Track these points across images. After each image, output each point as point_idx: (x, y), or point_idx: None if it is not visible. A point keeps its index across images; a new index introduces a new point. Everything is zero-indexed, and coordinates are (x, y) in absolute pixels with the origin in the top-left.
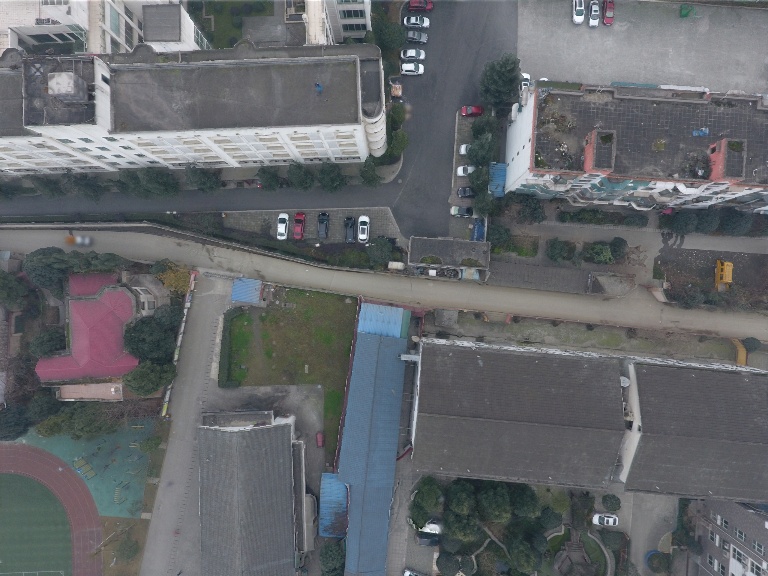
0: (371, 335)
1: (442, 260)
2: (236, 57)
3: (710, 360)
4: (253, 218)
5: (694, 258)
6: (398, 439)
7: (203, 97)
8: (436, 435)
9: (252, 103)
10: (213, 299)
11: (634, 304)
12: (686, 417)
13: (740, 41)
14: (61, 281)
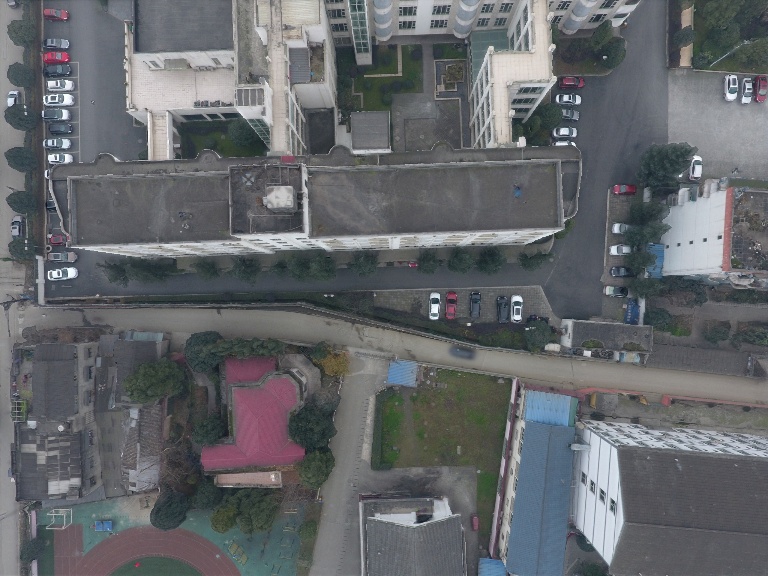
0: (541, 424)
1: (604, 344)
2: (434, 159)
3: None
4: (403, 297)
5: None
6: (567, 529)
7: (400, 199)
8: (640, 543)
9: (450, 205)
10: (363, 379)
11: None
12: None
13: None
14: (218, 365)
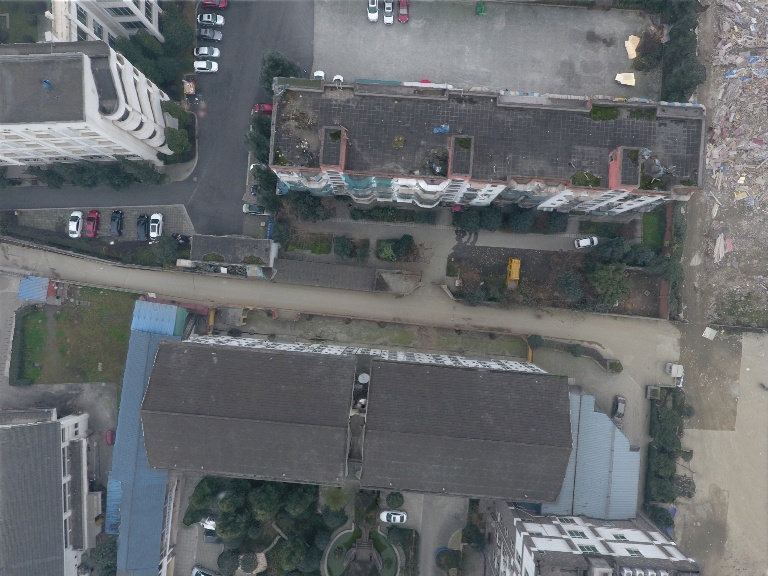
0: (142, 333)
1: (224, 258)
2: None
3: (501, 357)
4: (48, 216)
5: (487, 255)
6: None
7: None
8: (163, 432)
9: None
10: (8, 297)
11: (427, 301)
12: (412, 414)
13: (536, 38)
14: None
